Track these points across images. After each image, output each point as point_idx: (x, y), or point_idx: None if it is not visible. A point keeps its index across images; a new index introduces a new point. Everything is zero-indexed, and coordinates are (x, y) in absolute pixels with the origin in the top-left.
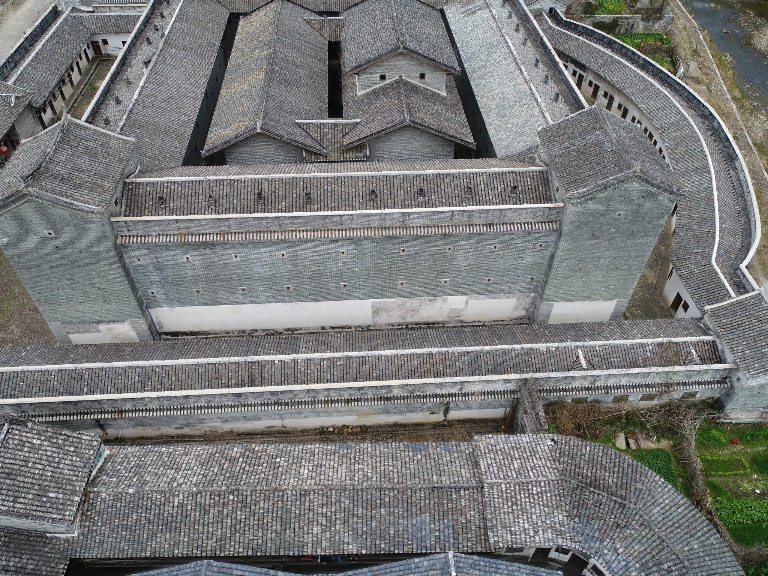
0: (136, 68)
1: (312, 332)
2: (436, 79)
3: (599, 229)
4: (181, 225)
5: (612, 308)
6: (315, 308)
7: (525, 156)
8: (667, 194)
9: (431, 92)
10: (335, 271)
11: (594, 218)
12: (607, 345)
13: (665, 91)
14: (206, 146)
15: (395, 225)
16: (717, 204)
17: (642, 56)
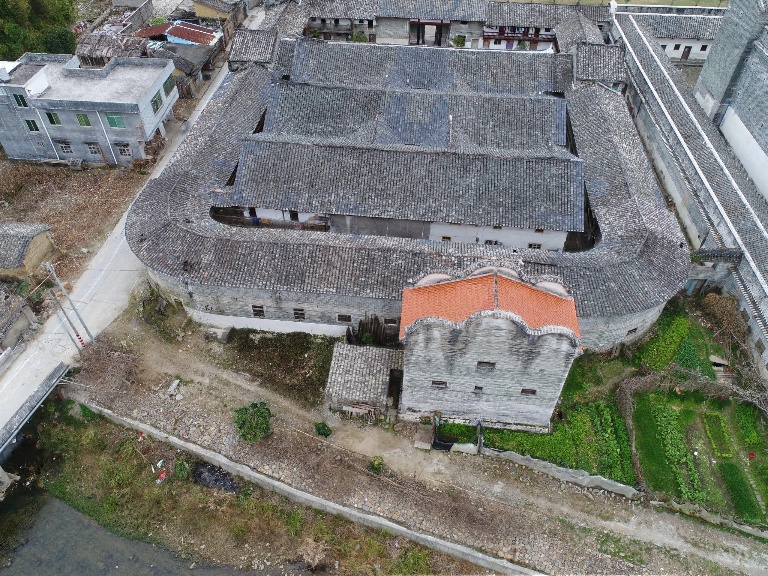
0: None
1: None
2: None
3: None
4: None
5: None
6: None
7: None
8: None
9: None
10: None
11: None
12: None
13: None
14: None
15: None
16: None
17: None
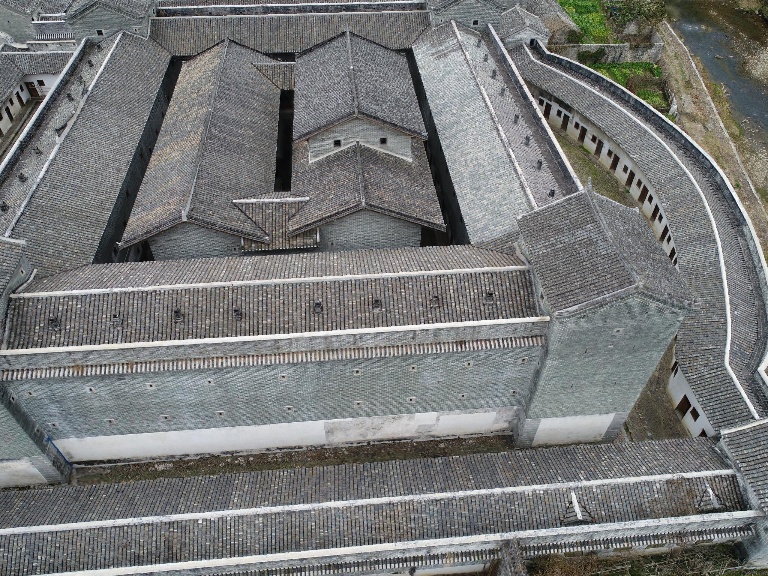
0: (51, 132)
1: (255, 454)
2: (400, 144)
3: (593, 346)
4: (76, 357)
5: (609, 421)
6: (256, 431)
7: (503, 245)
8: (676, 309)
9: (394, 159)
10: (276, 395)
11: (587, 336)
12: (606, 485)
13: (660, 139)
14: (125, 234)
15: (345, 347)
16: (726, 285)
17: (633, 96)
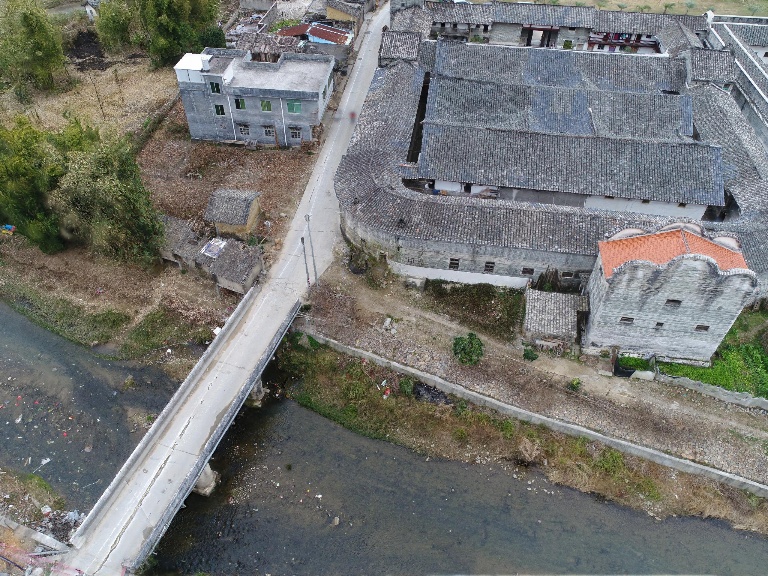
0: None
1: None
2: None
3: None
4: None
5: None
6: None
7: None
8: None
9: None
10: None
11: None
12: None
13: None
14: None
15: None
16: None
17: None
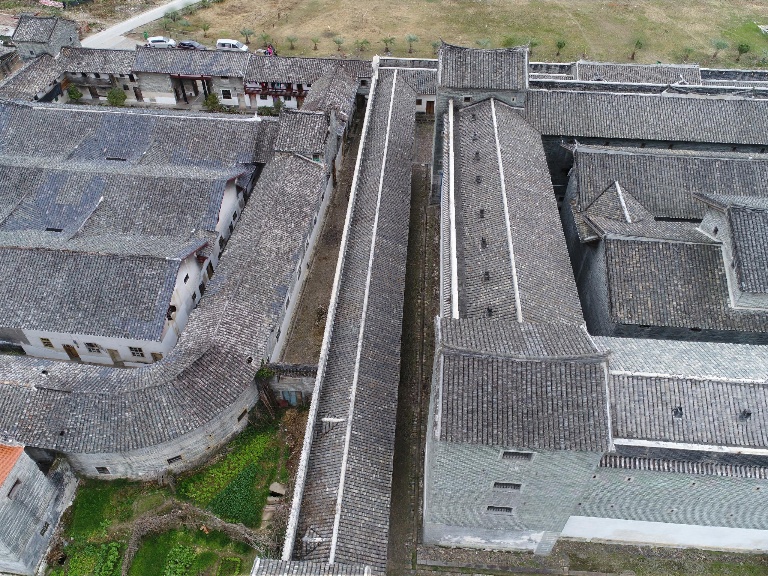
0: None
1: None
2: None
3: None
4: None
5: None
6: None
7: None
8: None
9: (719, 284)
10: None
11: None
12: None
13: None
14: None
15: None
16: None
17: None
